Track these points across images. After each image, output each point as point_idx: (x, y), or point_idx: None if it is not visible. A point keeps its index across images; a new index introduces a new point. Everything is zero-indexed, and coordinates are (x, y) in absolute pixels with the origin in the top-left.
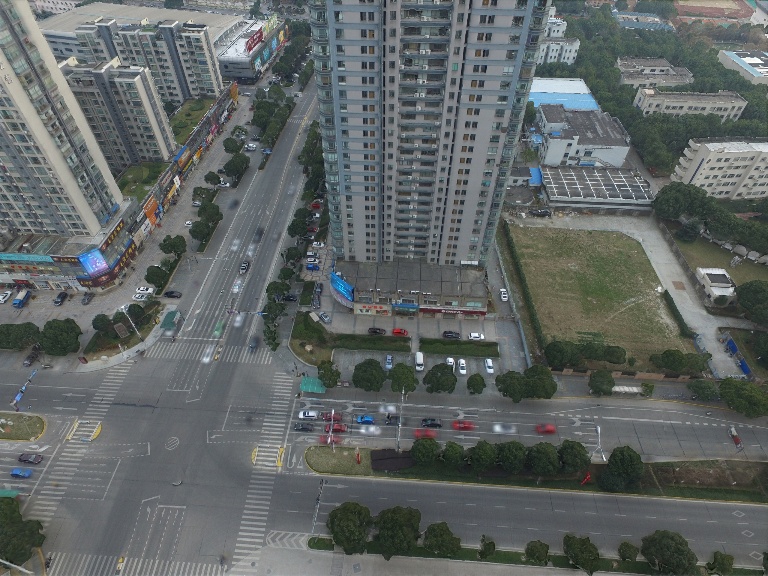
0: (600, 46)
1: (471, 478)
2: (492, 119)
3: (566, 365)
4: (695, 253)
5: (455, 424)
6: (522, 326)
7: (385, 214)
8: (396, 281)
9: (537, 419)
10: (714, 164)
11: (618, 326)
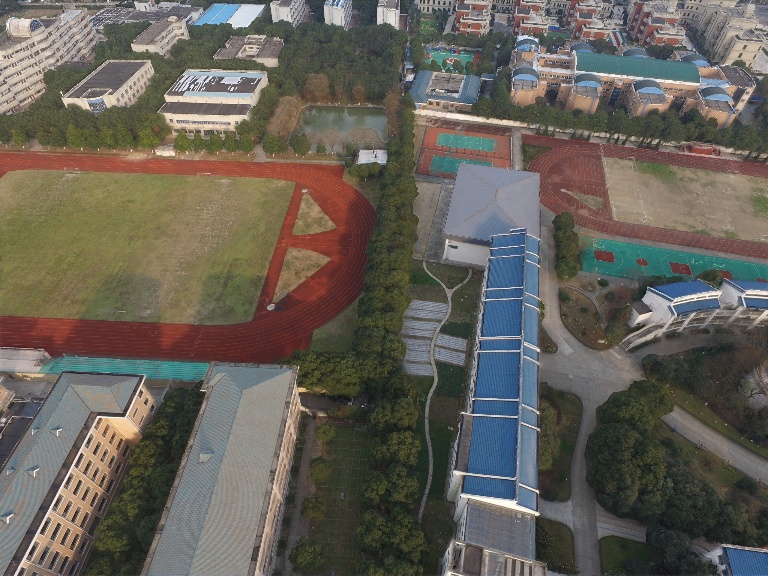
0: None
1: None
2: None
3: None
4: None
5: None
6: None
7: None
8: None
9: None
10: None
11: None
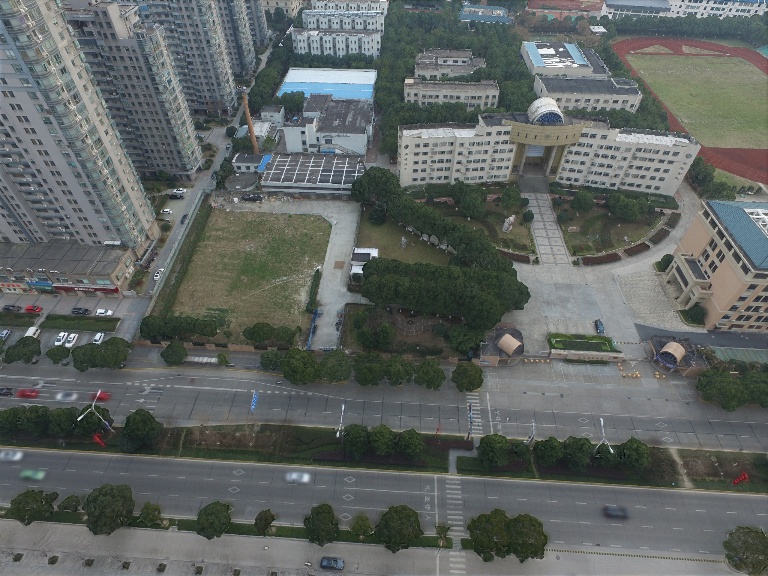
0: (413, 38)
1: (5, 441)
2: (30, 101)
3: (165, 338)
4: (377, 235)
5: (28, 393)
6: (157, 303)
7: (7, 195)
8: (37, 260)
9: (110, 388)
10: (415, 149)
11: (251, 303)
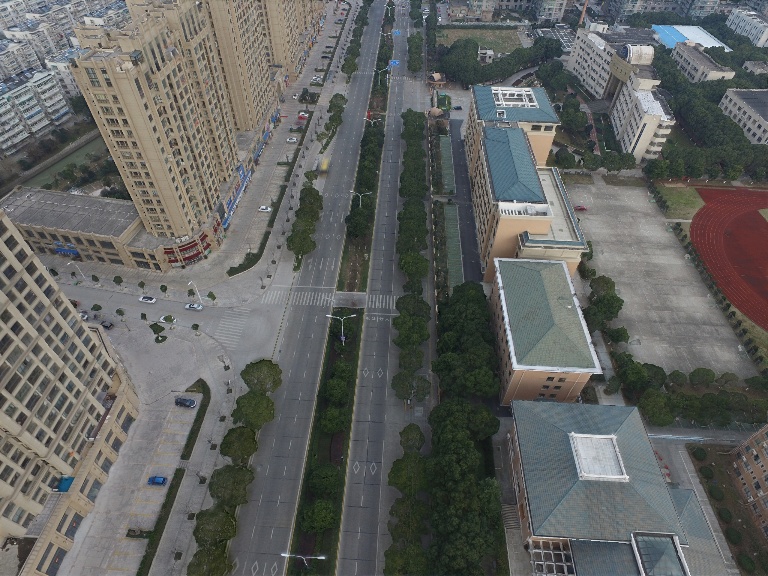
0: None
1: None
2: None
3: None
4: None
5: None
6: None
7: None
8: None
9: None
10: None
11: (453, 40)
